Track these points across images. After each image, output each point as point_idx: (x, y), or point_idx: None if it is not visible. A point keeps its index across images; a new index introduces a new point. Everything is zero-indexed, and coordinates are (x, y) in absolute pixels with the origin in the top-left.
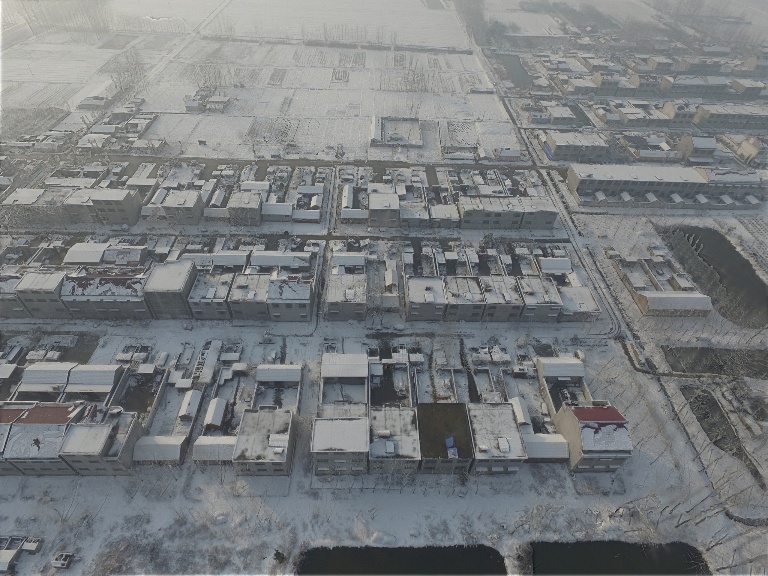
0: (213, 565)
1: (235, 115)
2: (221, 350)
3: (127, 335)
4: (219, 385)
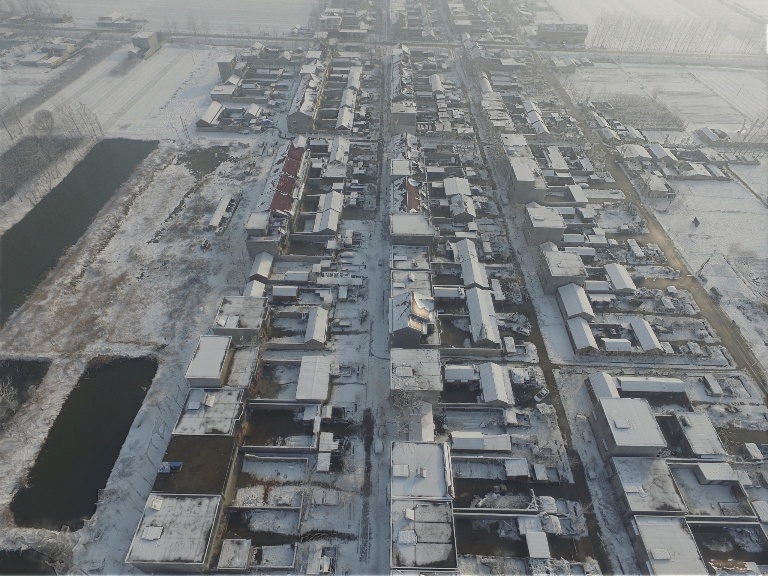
0: (172, 310)
1: None
2: (350, 285)
3: (375, 232)
4: (315, 291)
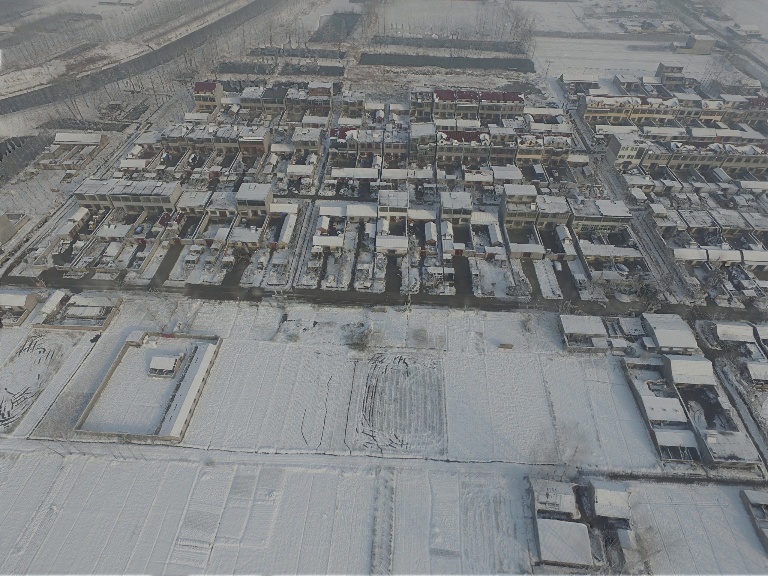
0: None
1: (494, 467)
2: None
3: None
4: None
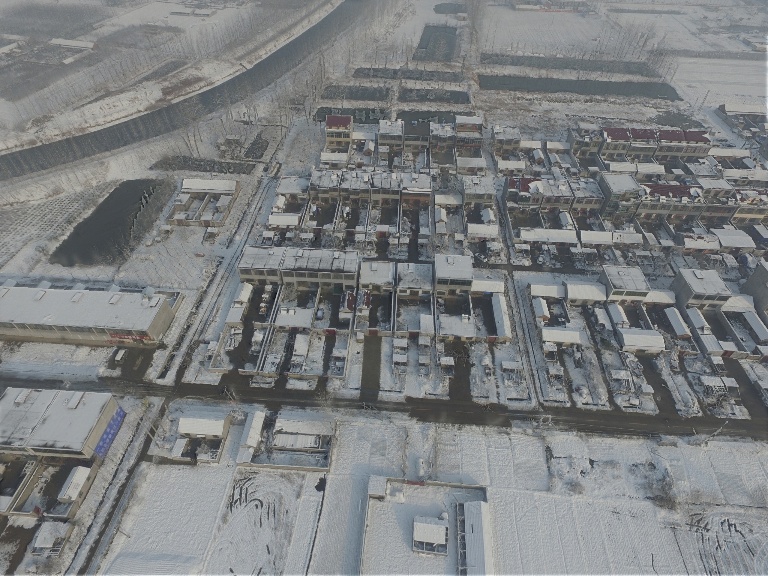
0: None
1: None
2: None
3: None
4: None
